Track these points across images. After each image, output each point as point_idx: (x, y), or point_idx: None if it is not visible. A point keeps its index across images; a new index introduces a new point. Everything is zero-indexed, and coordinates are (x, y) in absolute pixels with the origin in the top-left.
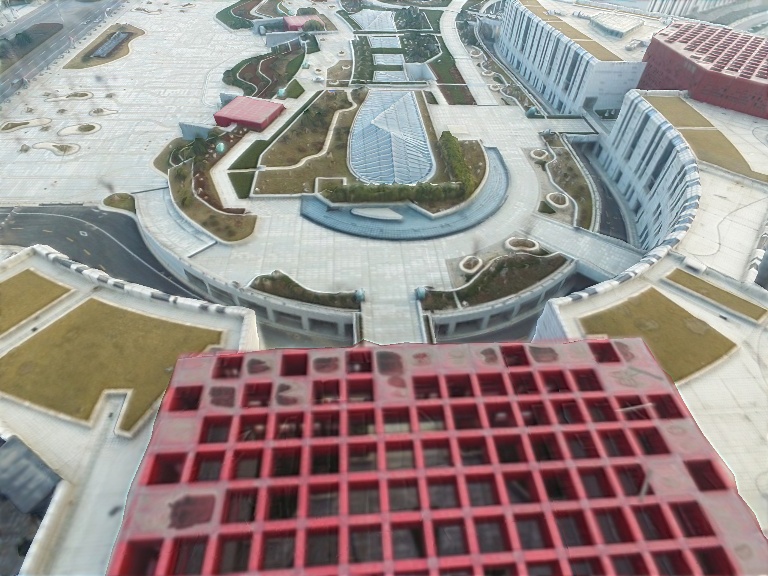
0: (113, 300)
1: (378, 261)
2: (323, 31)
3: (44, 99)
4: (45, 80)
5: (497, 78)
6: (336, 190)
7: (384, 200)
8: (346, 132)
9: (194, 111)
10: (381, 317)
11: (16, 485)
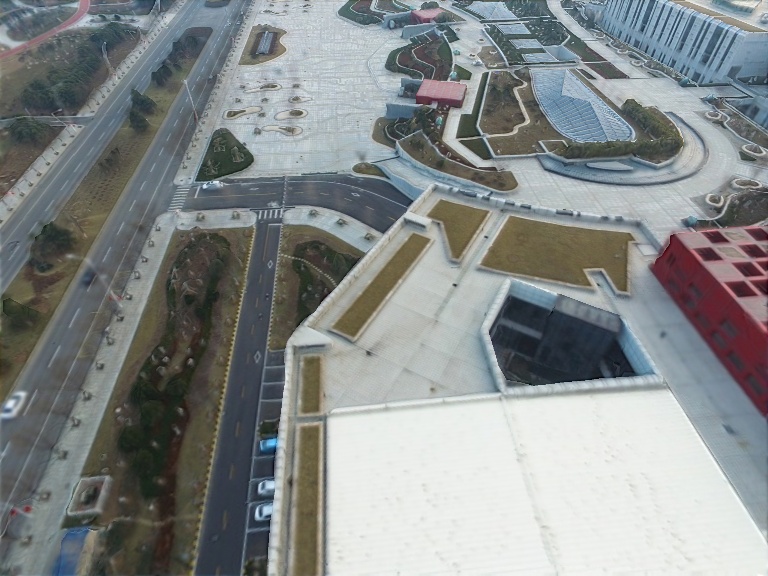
0: (526, 217)
1: (635, 201)
2: (454, 22)
3: (243, 91)
4: (231, 75)
5: (632, 55)
6: (572, 148)
7: (611, 155)
8: (536, 105)
9: (377, 95)
10: (667, 240)
11: (594, 319)
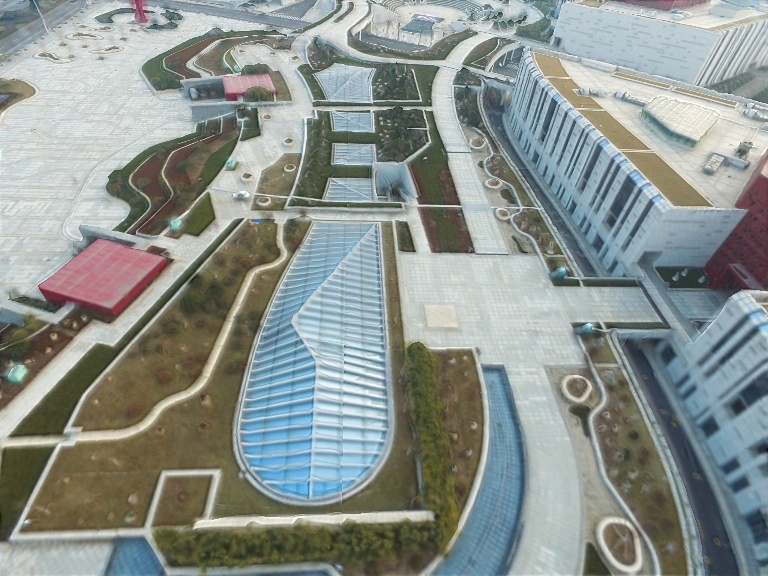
0: None
1: None
2: (271, 102)
3: None
4: None
5: (506, 192)
6: (175, 548)
7: None
8: (253, 327)
9: (41, 249)
10: None
11: None
